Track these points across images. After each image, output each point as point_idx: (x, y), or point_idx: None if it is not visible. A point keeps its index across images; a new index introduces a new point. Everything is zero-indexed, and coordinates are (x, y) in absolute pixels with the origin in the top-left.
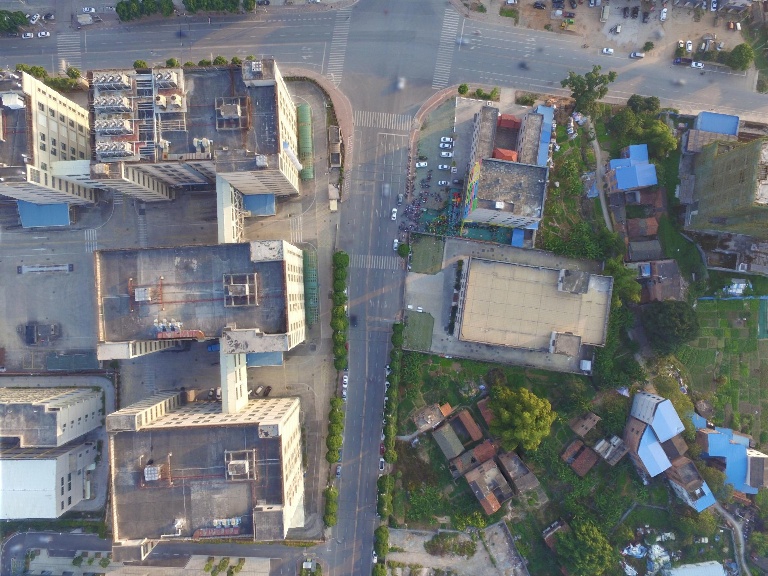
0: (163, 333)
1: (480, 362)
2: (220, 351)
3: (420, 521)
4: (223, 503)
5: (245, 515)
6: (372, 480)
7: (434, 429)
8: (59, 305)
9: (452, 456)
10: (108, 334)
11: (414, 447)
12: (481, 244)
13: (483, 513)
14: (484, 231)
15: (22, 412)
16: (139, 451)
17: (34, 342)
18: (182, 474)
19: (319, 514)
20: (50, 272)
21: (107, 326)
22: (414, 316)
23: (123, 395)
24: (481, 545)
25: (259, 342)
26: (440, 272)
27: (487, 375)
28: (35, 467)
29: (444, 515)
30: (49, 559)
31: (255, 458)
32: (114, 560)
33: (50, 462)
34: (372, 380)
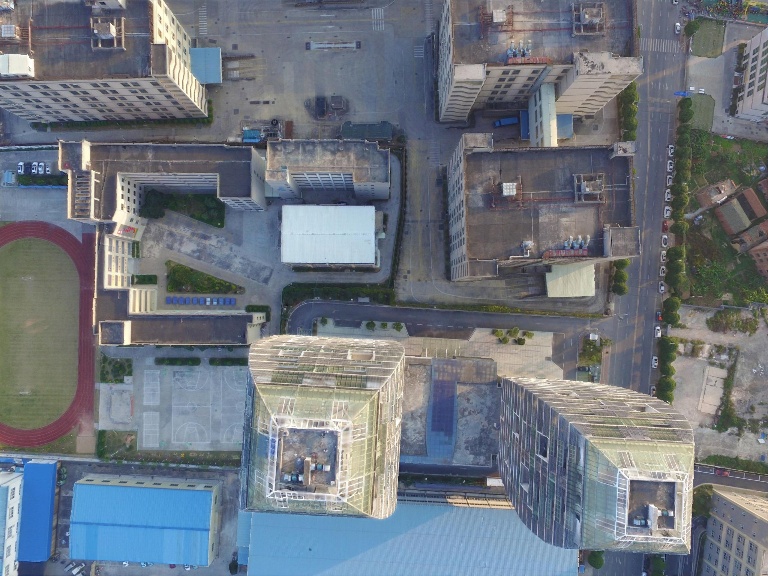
0: (514, 59)
1: (760, 144)
2: (542, 99)
3: (706, 295)
4: (570, 227)
5: (592, 239)
6: (654, 257)
7: (720, 204)
8: (346, 81)
9: (741, 229)
10: (457, 61)
11: (697, 224)
12: (761, 29)
13: (766, 290)
14: (763, 17)
15: (352, 150)
16: (488, 174)
17: (324, 114)
18: (531, 197)
19: (601, 290)
20: (338, 49)
21: (456, 53)
22: (695, 98)
23: (409, 170)
24: (763, 322)
25: (615, 63)
26: (721, 55)
27: (765, 158)
28: (354, 213)
29: (726, 292)
30: (335, 328)
31: (604, 182)
32: (470, 274)
33: (369, 208)
34: (654, 159)
